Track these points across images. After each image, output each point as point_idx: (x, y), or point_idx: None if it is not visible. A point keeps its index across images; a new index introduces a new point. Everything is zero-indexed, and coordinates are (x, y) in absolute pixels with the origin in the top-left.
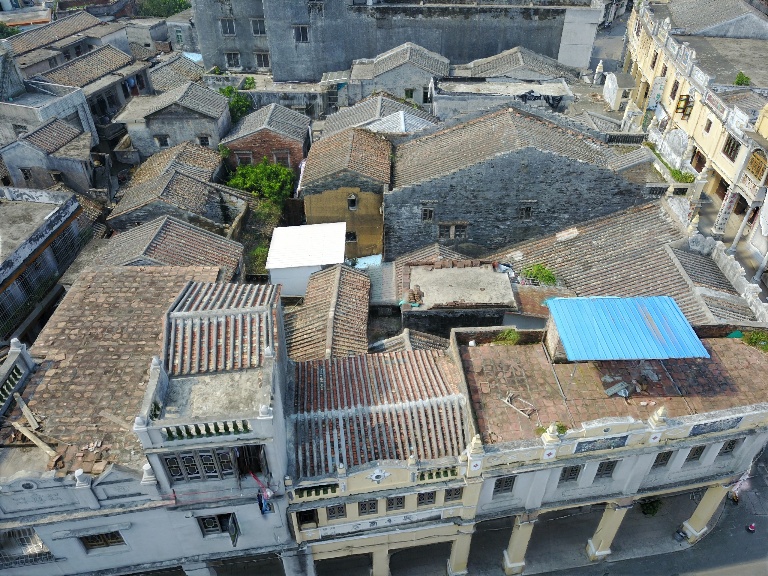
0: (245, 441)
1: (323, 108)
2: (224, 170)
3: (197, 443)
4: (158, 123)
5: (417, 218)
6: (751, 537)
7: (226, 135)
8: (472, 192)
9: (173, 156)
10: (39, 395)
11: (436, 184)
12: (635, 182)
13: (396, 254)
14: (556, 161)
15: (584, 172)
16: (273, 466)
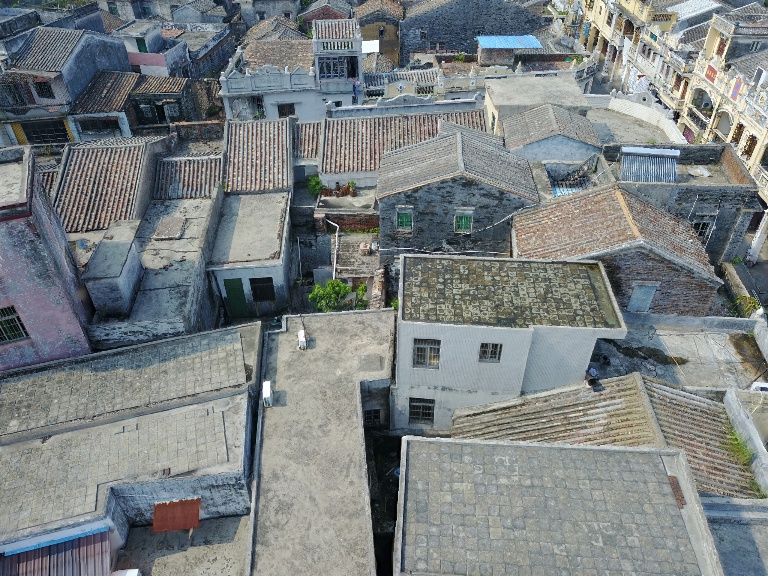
0: (352, 52)
1: (358, 5)
2: None
3: (334, 52)
4: (260, 3)
5: (418, 38)
6: None
7: (300, 13)
8: (448, 21)
9: (271, 20)
10: (252, 68)
11: (428, 15)
12: (536, 14)
13: (406, 63)
14: (492, 1)
15: (508, 8)
16: (360, 71)
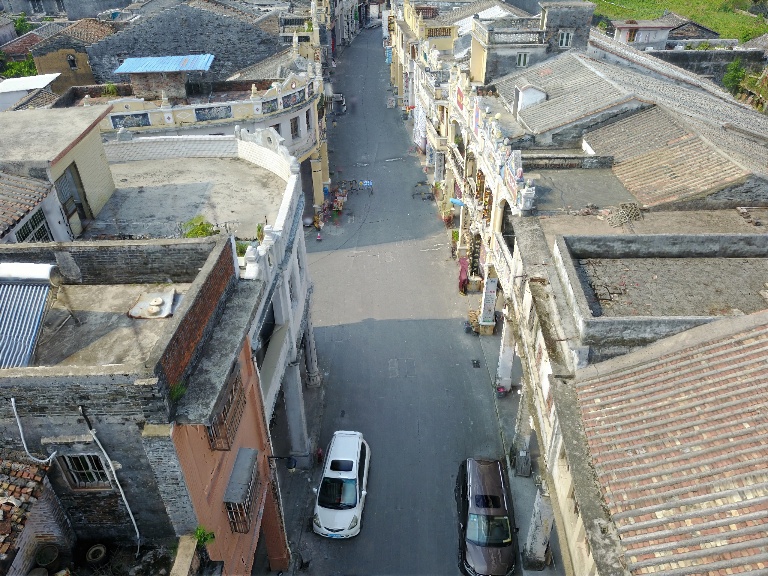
0: None
1: None
2: (3, 70)
3: None
4: None
5: None
6: (317, 243)
7: None
8: (152, 44)
9: None
10: None
11: (123, 37)
12: (271, 32)
13: None
14: (207, 16)
15: (230, 25)
16: None
